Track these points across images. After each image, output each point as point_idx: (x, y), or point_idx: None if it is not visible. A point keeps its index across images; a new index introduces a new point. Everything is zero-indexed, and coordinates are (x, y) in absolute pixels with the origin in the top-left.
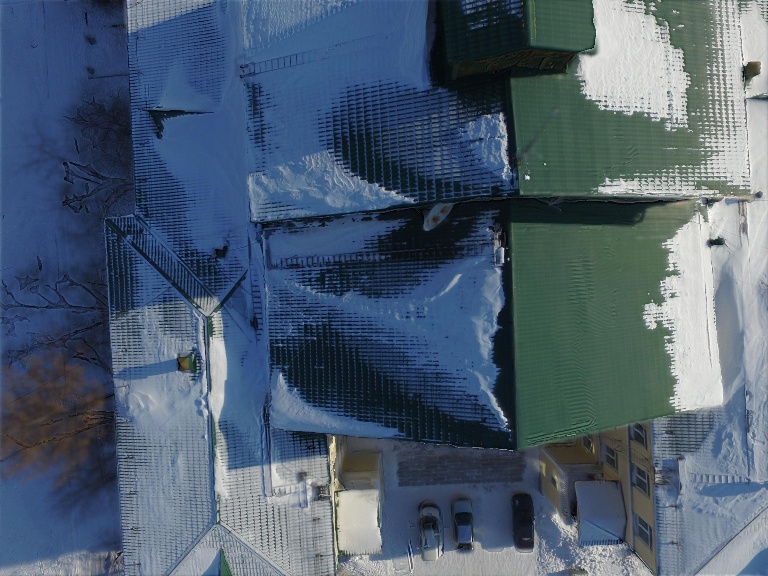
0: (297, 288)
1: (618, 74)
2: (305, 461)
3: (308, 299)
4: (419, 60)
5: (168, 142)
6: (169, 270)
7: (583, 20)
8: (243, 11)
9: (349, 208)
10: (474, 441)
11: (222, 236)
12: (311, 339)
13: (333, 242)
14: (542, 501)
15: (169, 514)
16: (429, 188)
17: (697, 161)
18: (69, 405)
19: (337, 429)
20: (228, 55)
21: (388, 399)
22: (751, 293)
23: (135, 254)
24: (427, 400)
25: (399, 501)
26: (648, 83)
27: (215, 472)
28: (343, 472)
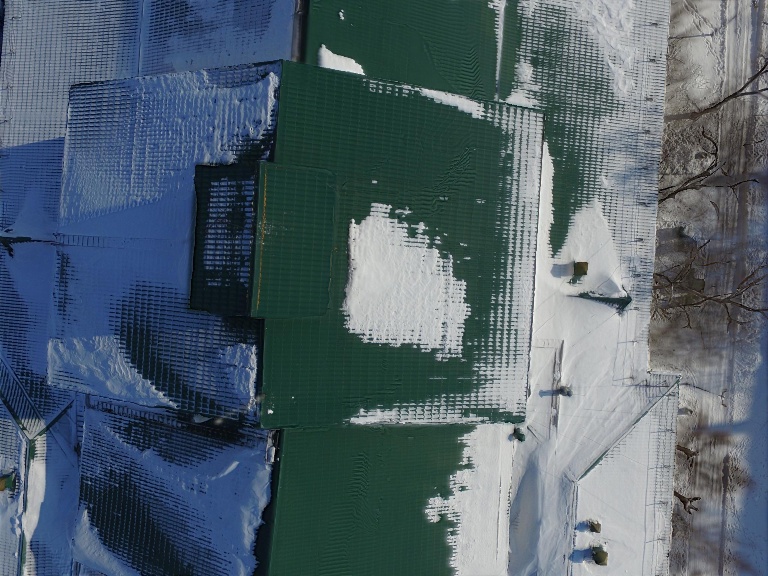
0: (108, 433)
1: (387, 308)
2: None
3: (116, 446)
4: None
5: (17, 262)
6: (3, 386)
7: (315, 289)
8: (62, 180)
9: (124, 397)
10: None
11: None
12: (114, 485)
13: None
14: None
15: None
16: (190, 398)
17: (467, 390)
18: None
19: None
20: None
21: (168, 562)
22: (553, 485)
23: None
24: (198, 573)
25: None
26: (421, 316)
27: None
28: None
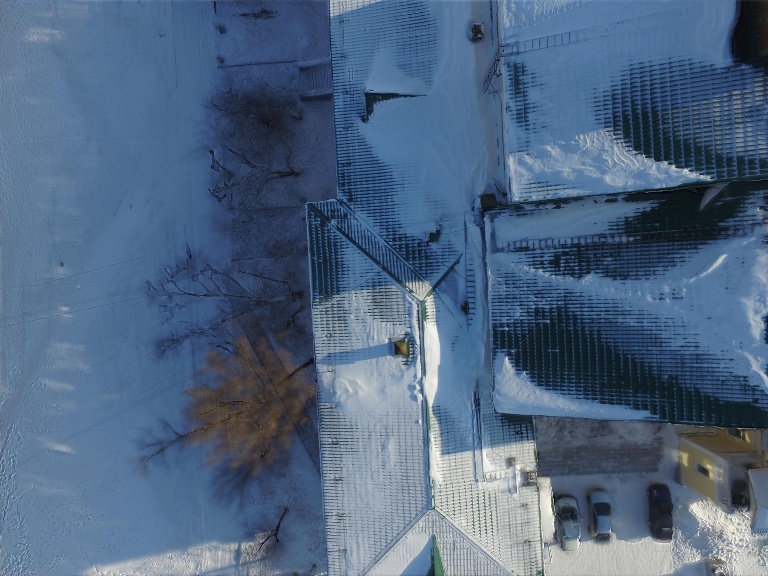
0: (527, 271)
1: None
2: (514, 446)
3: (540, 282)
4: (722, 36)
5: (376, 126)
6: (377, 254)
7: None
8: None
9: (632, 187)
10: (744, 422)
11: (434, 220)
12: (543, 322)
13: (571, 224)
14: (678, 491)
15: (378, 500)
16: (729, 165)
17: None
18: (198, 396)
19: (577, 412)
20: (441, 38)
21: (637, 381)
22: None
23: (340, 238)
24: (685, 382)
25: None
26: None
27: (430, 457)
28: None
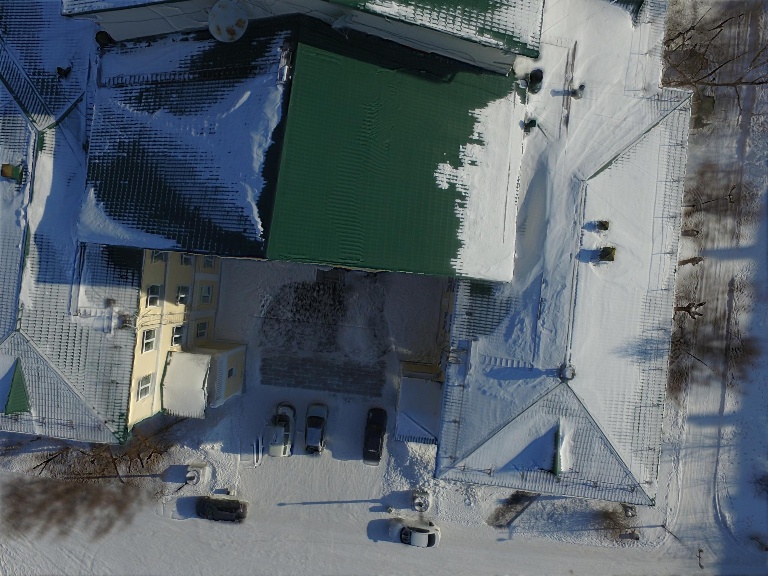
0: (118, 106)
1: None
2: (116, 289)
3: (125, 117)
4: None
5: None
6: (15, 85)
7: None
8: None
9: None
10: (234, 250)
11: (68, 57)
12: (122, 155)
13: (154, 61)
14: None
15: None
16: None
17: (482, 8)
18: None
19: (128, 240)
20: None
21: (174, 212)
22: (562, 185)
23: None
24: (204, 212)
25: (259, 398)
26: None
27: (23, 281)
28: (193, 346)
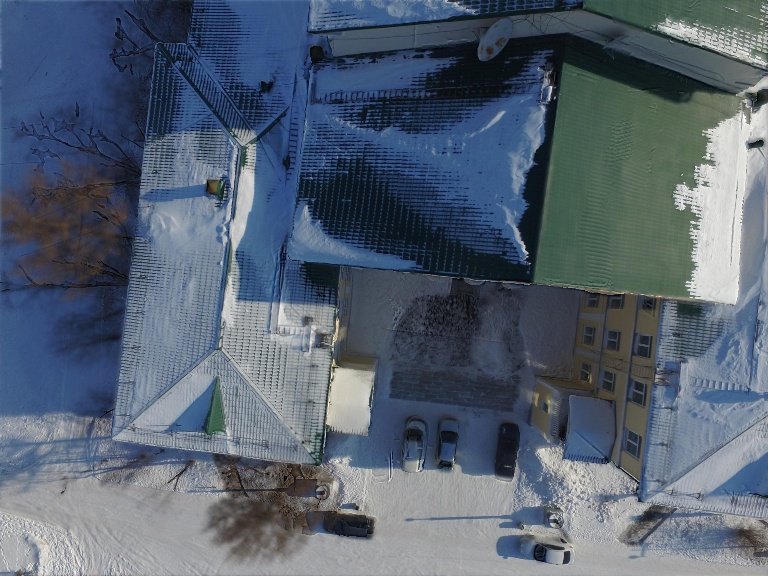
0: (337, 122)
1: None
2: (314, 307)
3: (346, 133)
4: None
5: None
6: (212, 99)
7: None
8: None
9: (409, 18)
10: (492, 273)
11: (270, 72)
12: (343, 173)
13: (381, 78)
14: (529, 434)
15: (172, 336)
16: (492, 0)
17: (755, 30)
18: (79, 267)
19: (355, 260)
20: None
21: (411, 232)
22: None
23: (181, 79)
24: (450, 233)
25: (387, 412)
26: None
27: (225, 299)
28: (340, 360)
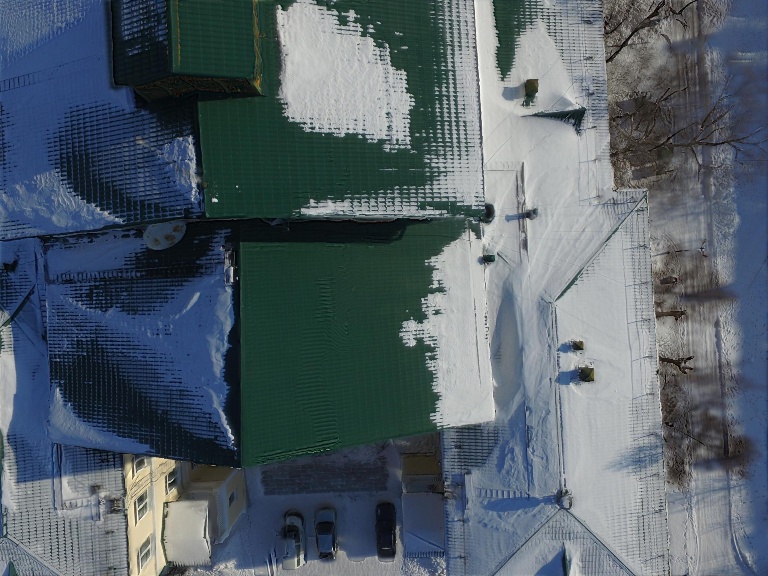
0: (70, 303)
1: (326, 96)
2: (98, 474)
3: (79, 315)
4: None
5: None
6: None
7: (239, 46)
8: None
9: (71, 228)
10: (208, 459)
11: (13, 250)
12: (82, 354)
13: (99, 258)
14: None
15: None
16: (135, 209)
17: (421, 182)
18: None
19: (100, 444)
20: None
21: (142, 415)
22: (530, 309)
23: None
24: (172, 417)
25: (265, 510)
26: (363, 105)
27: (2, 485)
28: (189, 482)
